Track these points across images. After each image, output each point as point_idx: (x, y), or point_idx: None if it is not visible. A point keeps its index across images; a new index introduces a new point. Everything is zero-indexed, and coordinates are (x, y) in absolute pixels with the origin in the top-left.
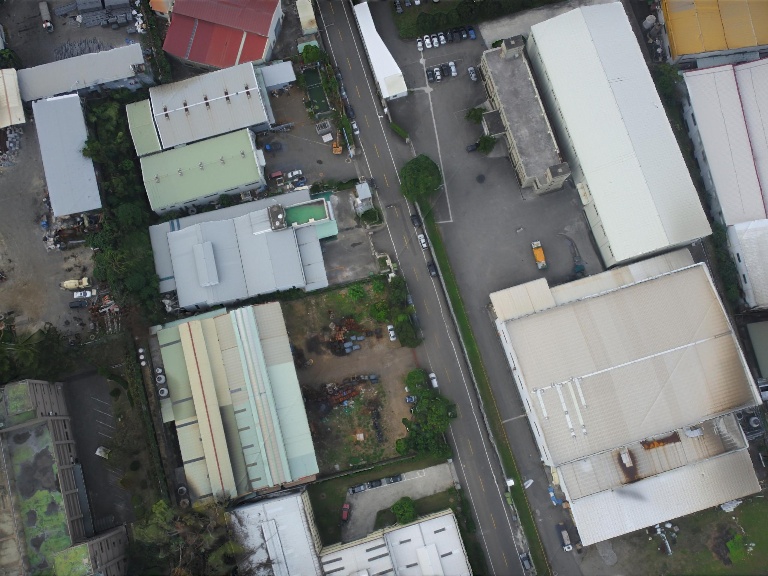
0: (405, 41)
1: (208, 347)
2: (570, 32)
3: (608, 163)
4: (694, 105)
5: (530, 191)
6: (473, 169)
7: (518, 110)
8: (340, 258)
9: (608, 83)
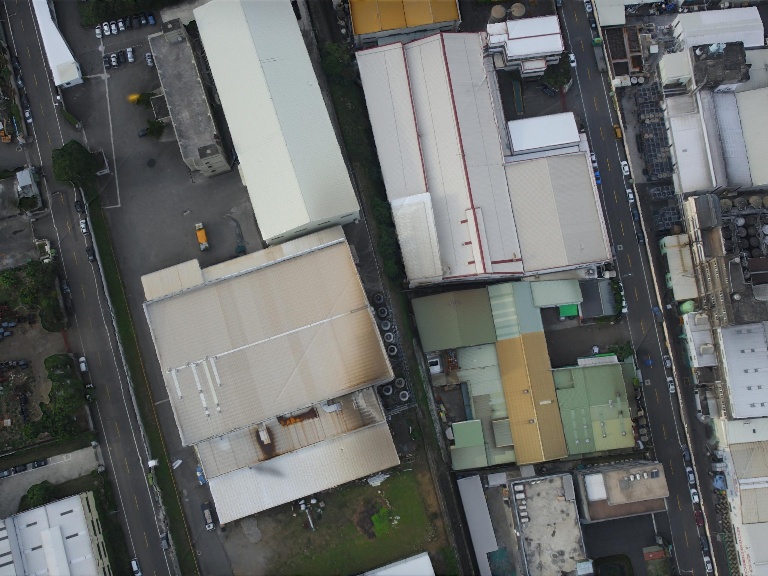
0: (86, 29)
1: None
2: (227, 14)
3: (258, 143)
4: (364, 84)
5: (199, 174)
6: (144, 154)
7: (180, 93)
8: (1, 246)
9: (259, 63)
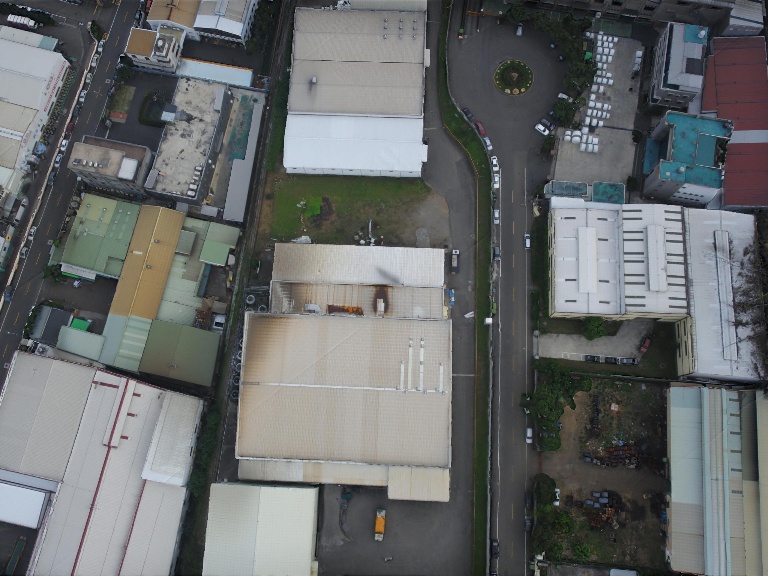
0: None
1: (759, 547)
2: None
3: None
4: None
5: None
6: None
7: None
8: None
9: None
